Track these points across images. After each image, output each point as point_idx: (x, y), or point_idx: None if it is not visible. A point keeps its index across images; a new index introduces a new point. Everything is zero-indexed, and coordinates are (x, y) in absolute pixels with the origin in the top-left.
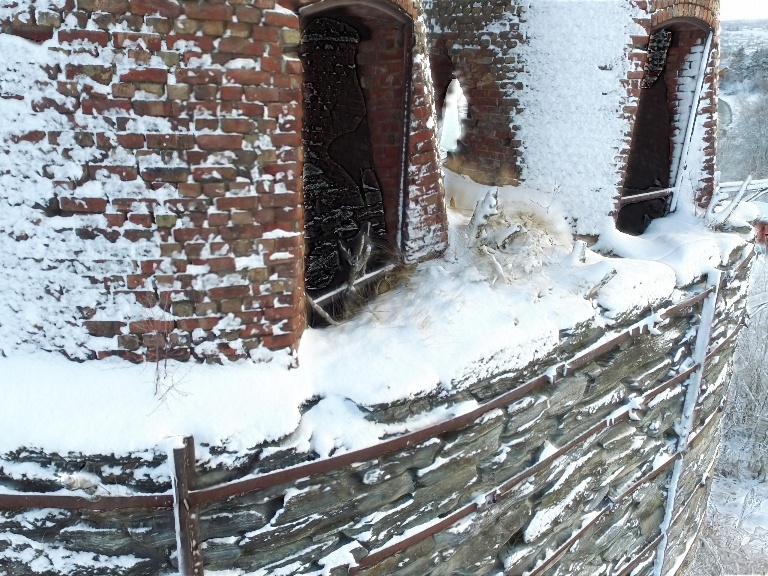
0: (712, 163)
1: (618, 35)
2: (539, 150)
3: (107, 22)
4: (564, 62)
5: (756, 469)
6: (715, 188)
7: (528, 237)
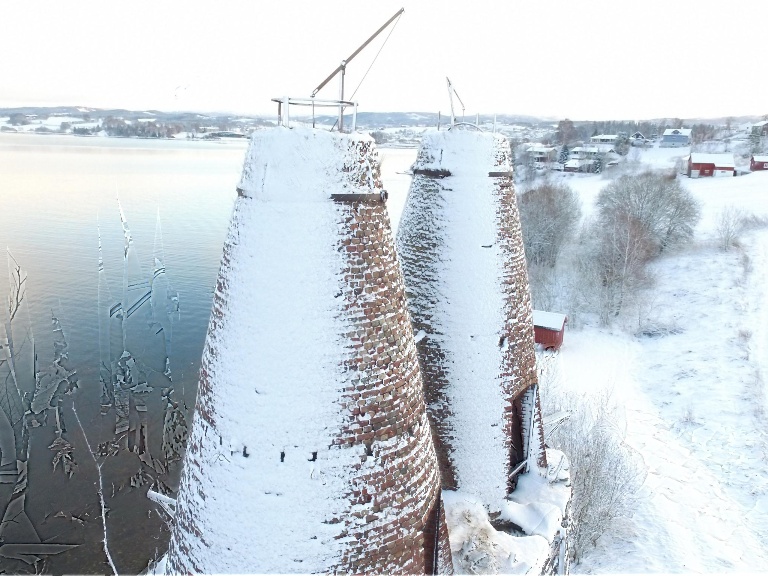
0: (544, 444)
1: (499, 409)
2: (466, 471)
3: (364, 568)
4: (474, 425)
5: (572, 554)
6: (549, 462)
7: (489, 556)
